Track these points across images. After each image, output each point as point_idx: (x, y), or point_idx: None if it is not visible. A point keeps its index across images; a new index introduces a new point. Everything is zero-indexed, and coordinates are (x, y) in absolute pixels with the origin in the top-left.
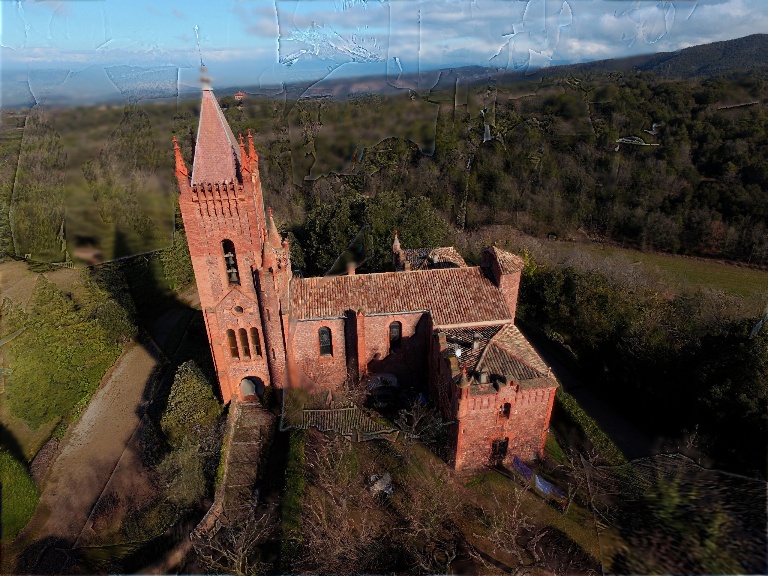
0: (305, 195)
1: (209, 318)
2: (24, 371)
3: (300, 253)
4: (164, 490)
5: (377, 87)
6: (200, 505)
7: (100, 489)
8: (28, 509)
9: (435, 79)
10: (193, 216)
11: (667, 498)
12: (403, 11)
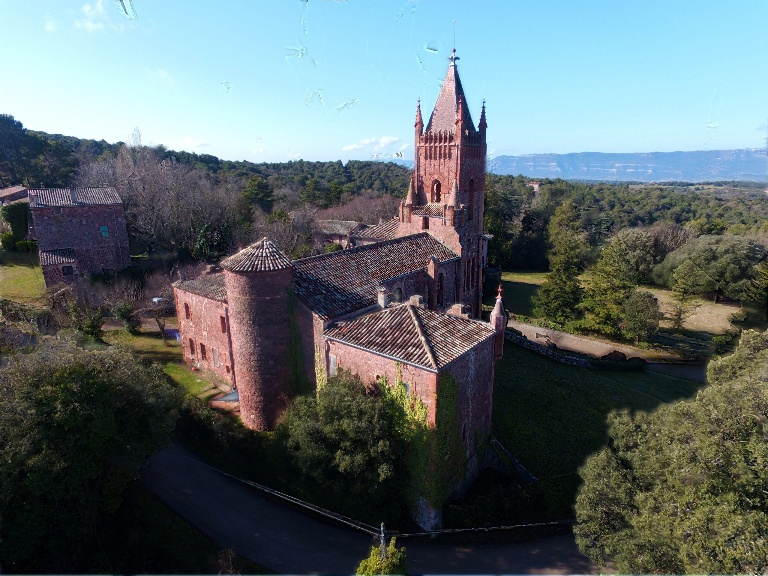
0: None
1: None
2: None
3: None
4: None
5: None
6: None
7: None
8: None
9: None
10: None
11: (161, 142)
12: None
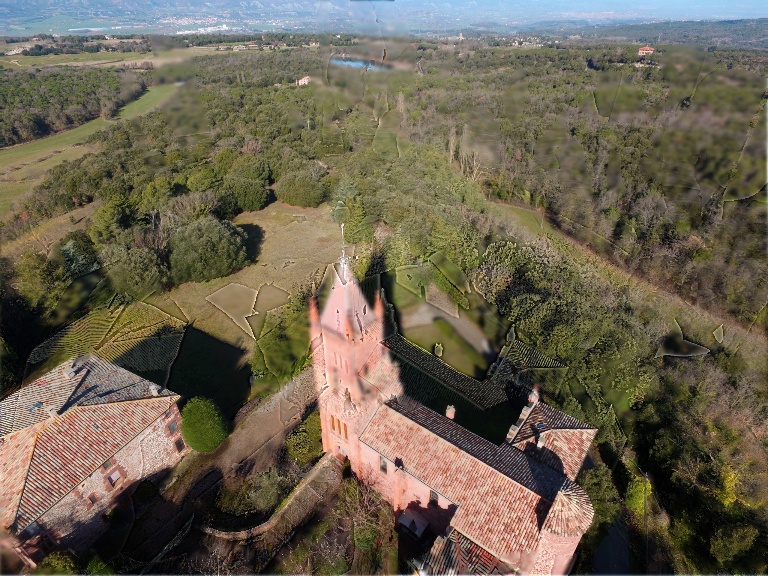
0: None
1: None
2: (260, 351)
3: None
4: (248, 494)
5: None
6: (264, 515)
7: (252, 452)
8: (214, 444)
9: (754, 189)
10: None
11: None
12: (738, 98)
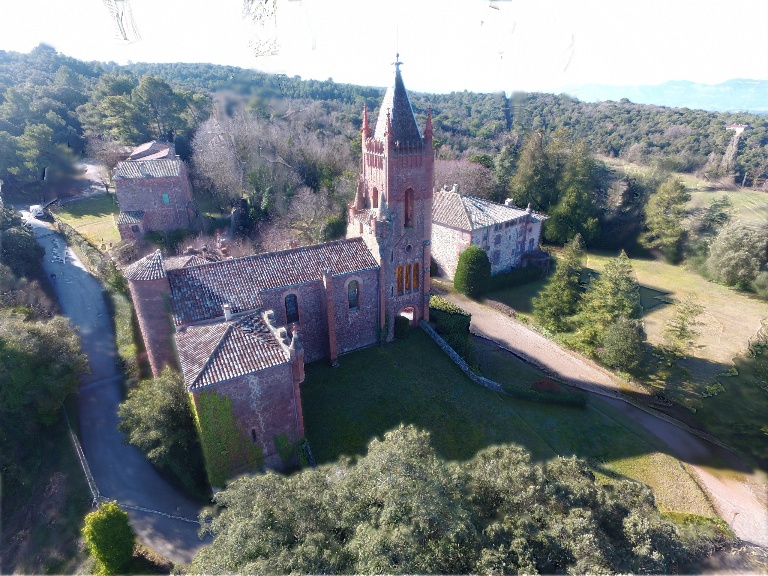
0: None
1: None
2: None
3: None
4: None
5: (253, 70)
6: None
7: None
8: (456, 283)
9: None
10: None
11: None
12: None
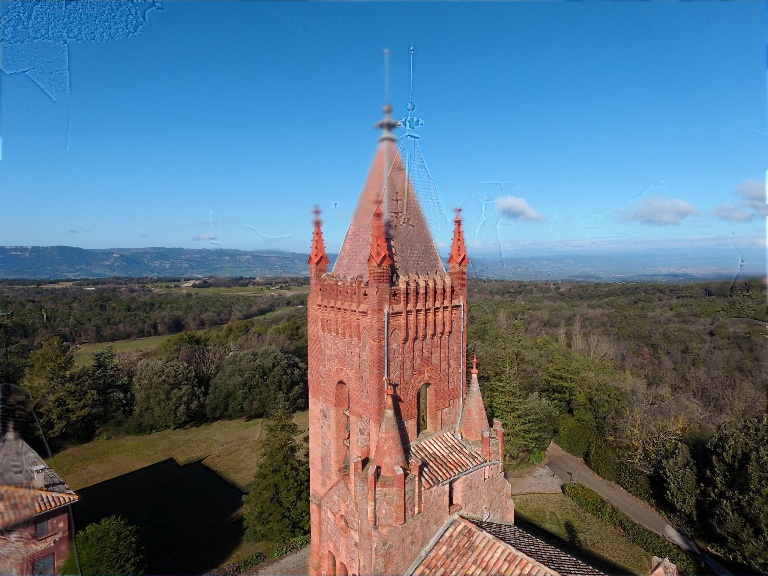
0: (761, 396)
1: (312, 511)
2: (261, 473)
3: (690, 488)
4: None
5: None
6: None
7: None
8: None
9: None
10: (316, 329)
11: None
12: None
